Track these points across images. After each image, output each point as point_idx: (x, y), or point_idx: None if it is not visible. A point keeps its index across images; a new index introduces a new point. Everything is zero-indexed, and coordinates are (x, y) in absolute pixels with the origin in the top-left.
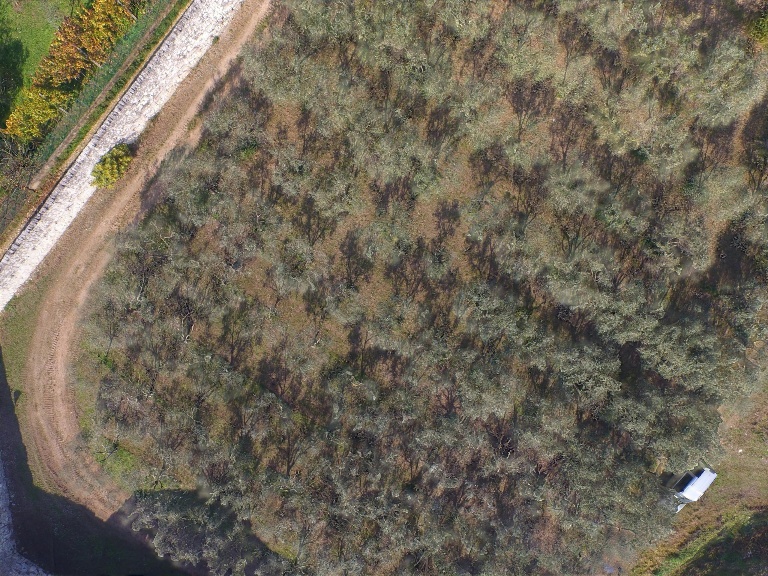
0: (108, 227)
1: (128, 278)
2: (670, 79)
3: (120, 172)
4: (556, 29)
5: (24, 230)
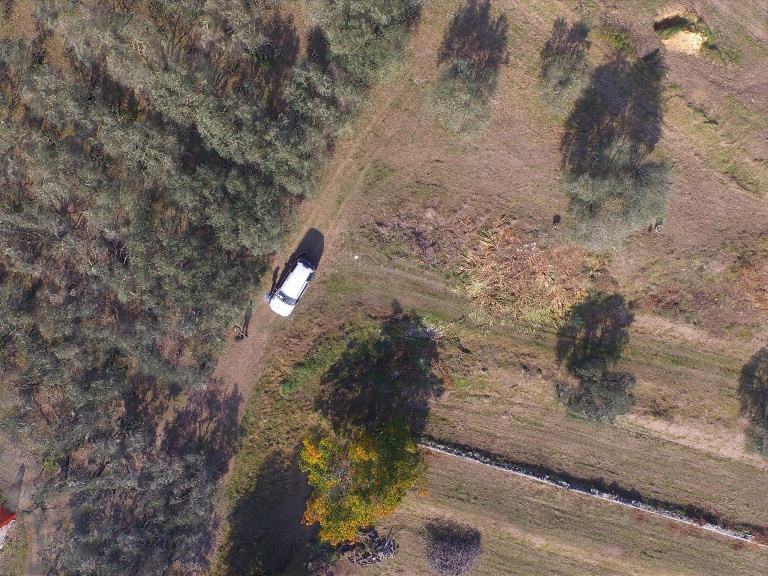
0: None
1: None
2: None
3: None
4: None
5: None
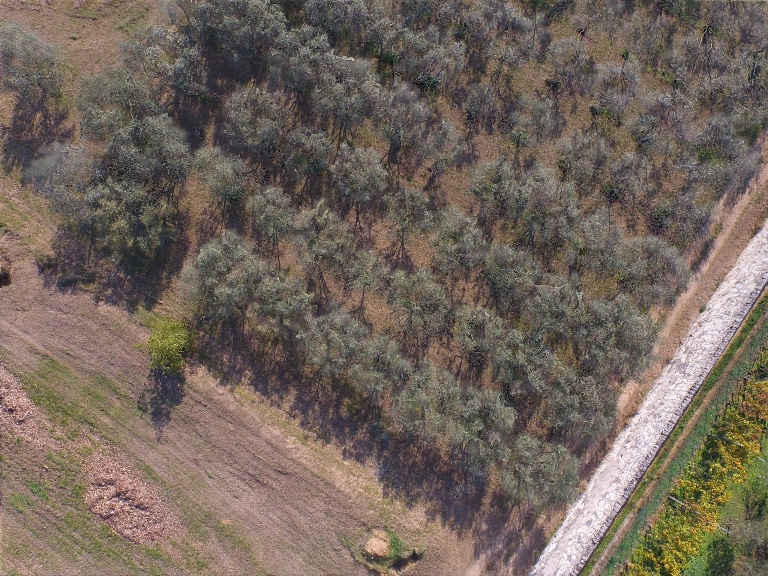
0: None
1: (767, 82)
2: (263, 294)
3: None
4: (376, 336)
5: None
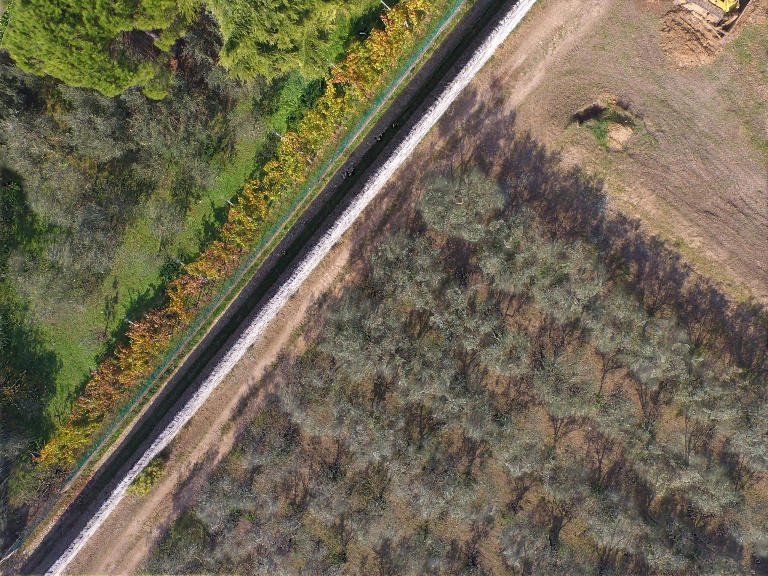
0: (140, 526)
1: None
2: None
3: (153, 483)
4: (593, 342)
5: (58, 559)
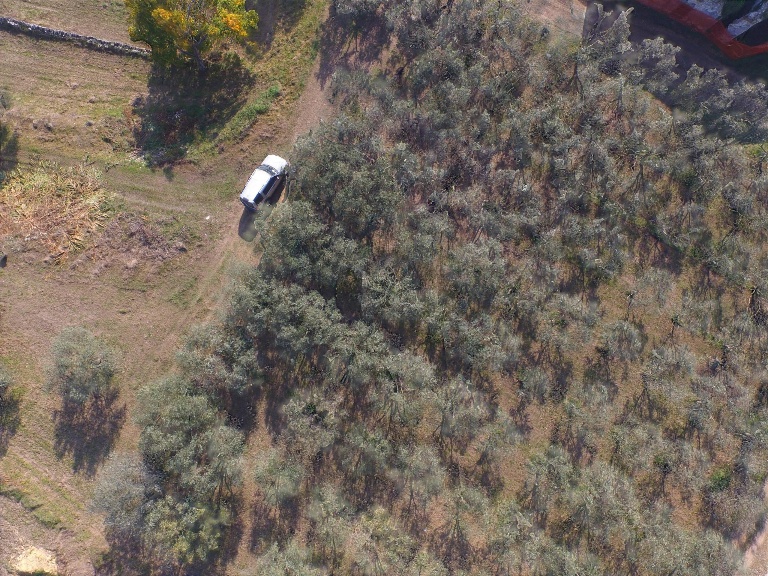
0: None
1: None
2: None
3: None
4: None
5: None
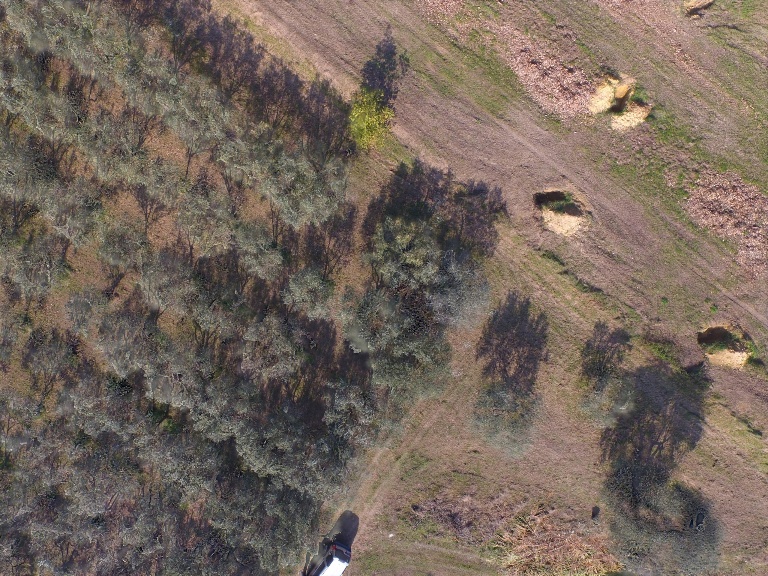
0: None
1: None
2: None
3: None
4: (176, 126)
5: None
